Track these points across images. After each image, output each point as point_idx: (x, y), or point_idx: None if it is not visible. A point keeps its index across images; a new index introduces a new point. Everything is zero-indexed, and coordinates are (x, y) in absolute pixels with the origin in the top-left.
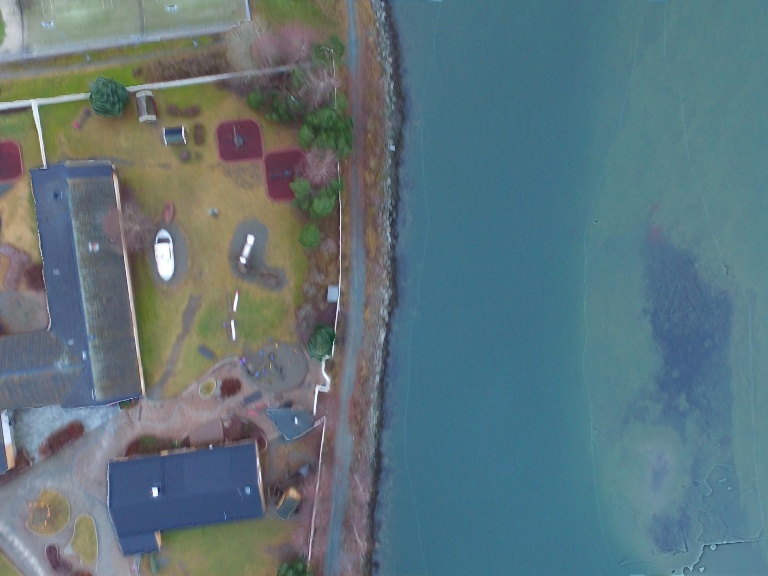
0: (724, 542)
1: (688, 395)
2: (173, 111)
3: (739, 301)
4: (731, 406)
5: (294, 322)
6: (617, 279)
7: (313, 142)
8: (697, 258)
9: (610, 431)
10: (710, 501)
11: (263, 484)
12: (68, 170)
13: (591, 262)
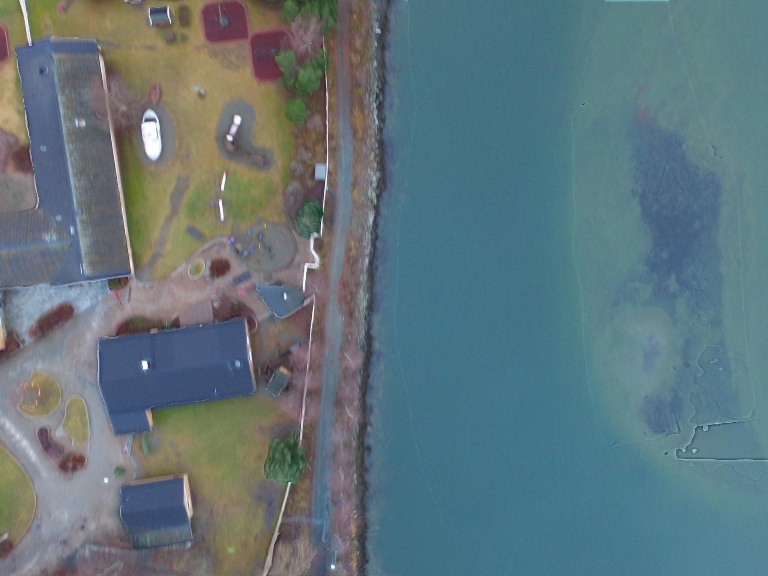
0: (716, 423)
1: (678, 276)
2: None
3: (727, 182)
4: (721, 287)
5: (282, 199)
6: (605, 161)
7: (297, 14)
8: (684, 139)
9: (600, 313)
10: (702, 382)
11: (254, 365)
12: (53, 45)
13: (579, 144)
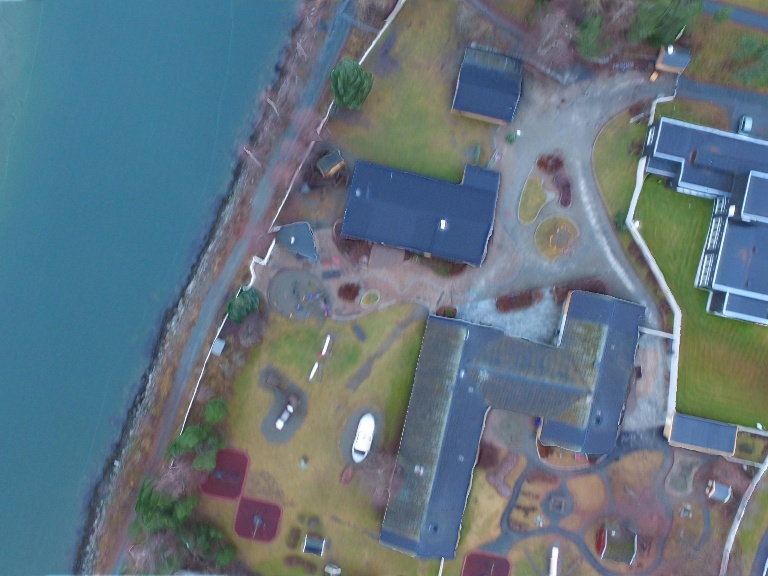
0: None
1: None
2: (310, 568)
3: None
4: None
5: None
6: None
7: (177, 501)
8: None
9: None
10: None
11: None
12: (416, 549)
13: None
